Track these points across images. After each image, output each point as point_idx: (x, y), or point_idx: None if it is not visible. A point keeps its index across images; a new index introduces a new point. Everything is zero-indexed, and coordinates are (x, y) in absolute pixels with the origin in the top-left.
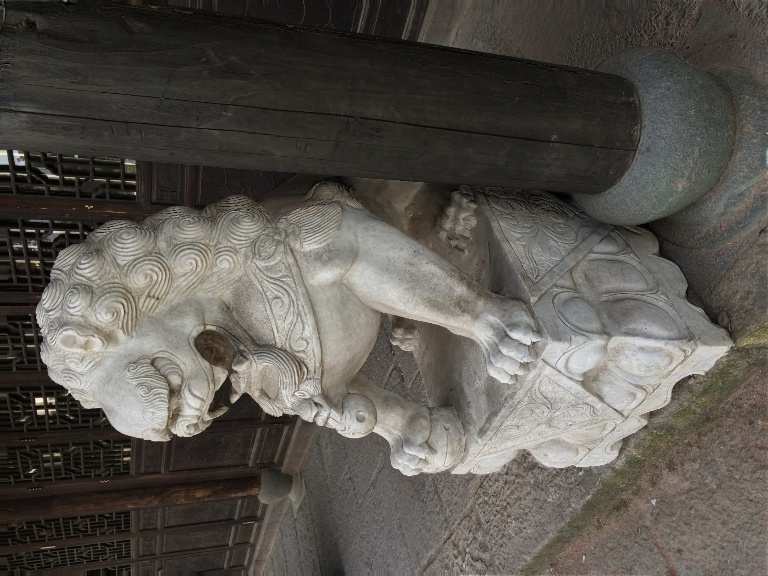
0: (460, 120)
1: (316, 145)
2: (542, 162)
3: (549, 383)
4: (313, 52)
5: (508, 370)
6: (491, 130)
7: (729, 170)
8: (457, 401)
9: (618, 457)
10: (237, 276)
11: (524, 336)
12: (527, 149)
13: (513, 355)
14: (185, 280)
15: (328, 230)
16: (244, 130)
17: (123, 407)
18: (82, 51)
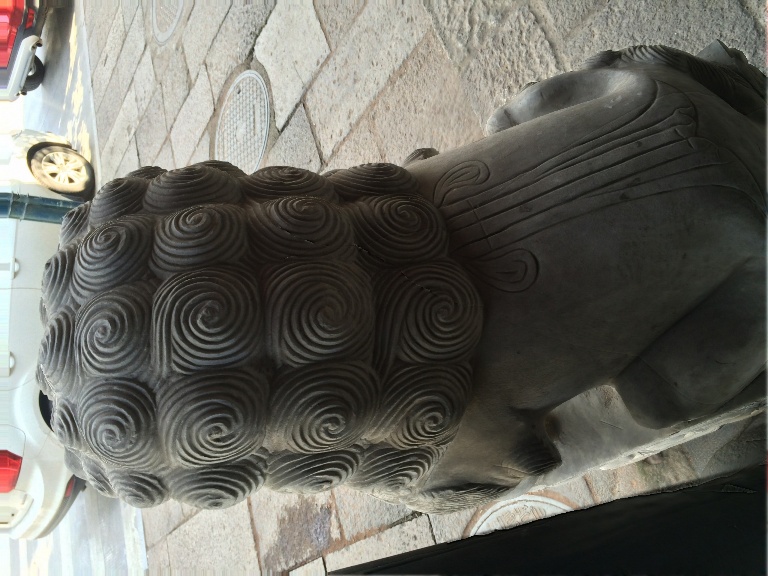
0: None
1: None
2: None
3: None
4: None
5: None
6: None
7: None
8: None
9: None
10: None
11: None
12: None
13: None
14: None
15: None
16: None
17: None
18: None
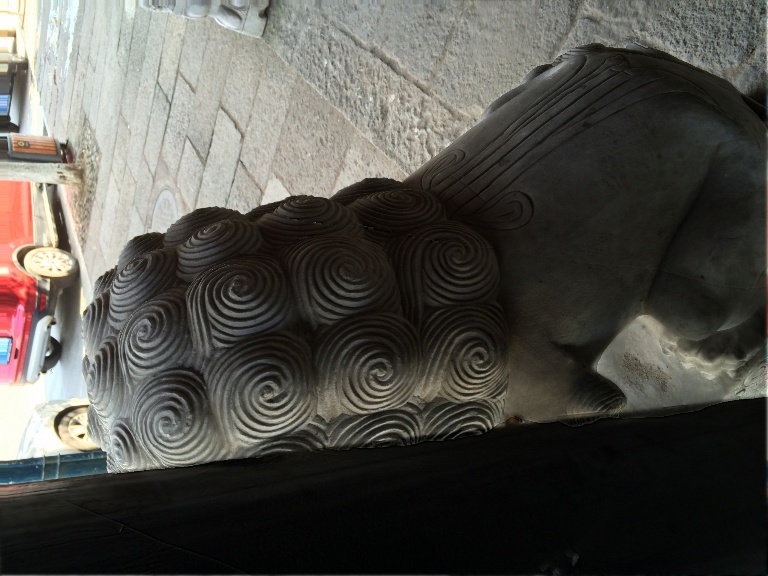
0: None
1: None
2: None
3: None
4: None
5: None
6: None
7: None
8: None
9: None
10: None
11: None
12: None
13: None
14: None
15: None
16: None
17: None
18: None
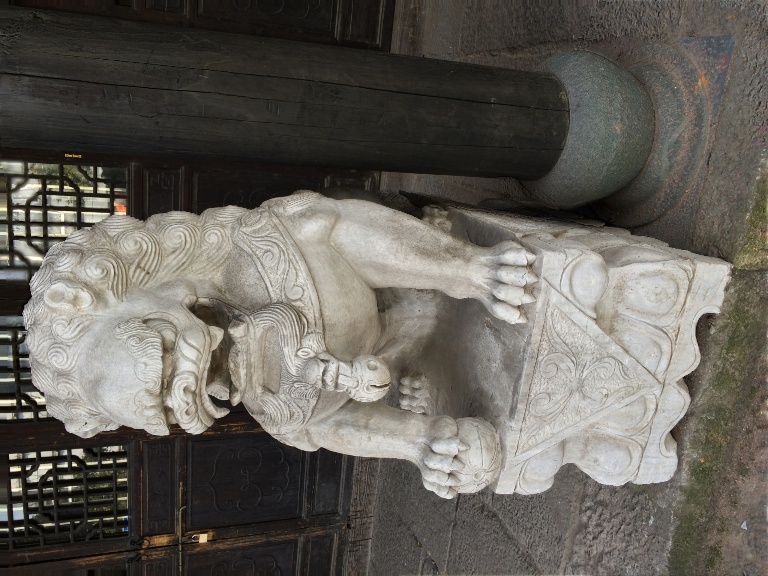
0: (407, 85)
1: (285, 107)
2: (489, 123)
3: (562, 319)
4: (272, 41)
5: (514, 298)
6: (436, 93)
7: (658, 126)
8: (480, 407)
9: (680, 469)
10: (226, 253)
11: (518, 254)
12: (472, 110)
13: (513, 277)
14: (175, 259)
15: (308, 198)
16: (220, 92)
17: (113, 366)
18: (79, 31)
